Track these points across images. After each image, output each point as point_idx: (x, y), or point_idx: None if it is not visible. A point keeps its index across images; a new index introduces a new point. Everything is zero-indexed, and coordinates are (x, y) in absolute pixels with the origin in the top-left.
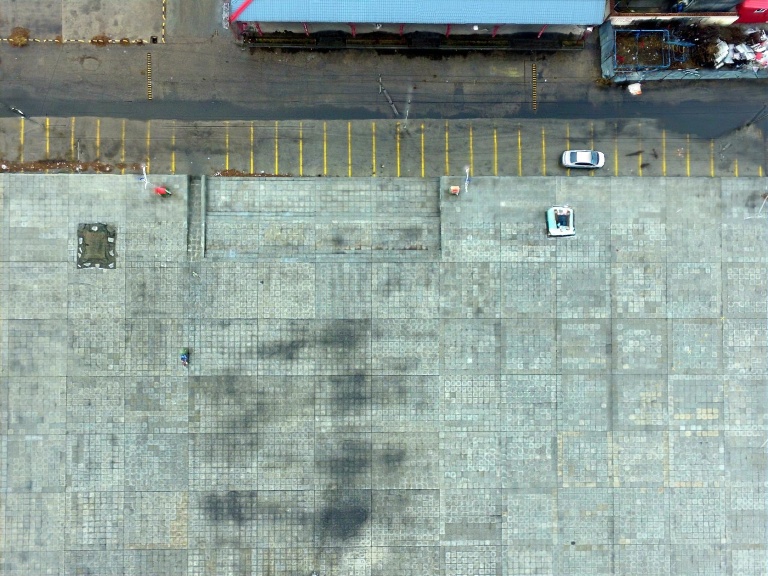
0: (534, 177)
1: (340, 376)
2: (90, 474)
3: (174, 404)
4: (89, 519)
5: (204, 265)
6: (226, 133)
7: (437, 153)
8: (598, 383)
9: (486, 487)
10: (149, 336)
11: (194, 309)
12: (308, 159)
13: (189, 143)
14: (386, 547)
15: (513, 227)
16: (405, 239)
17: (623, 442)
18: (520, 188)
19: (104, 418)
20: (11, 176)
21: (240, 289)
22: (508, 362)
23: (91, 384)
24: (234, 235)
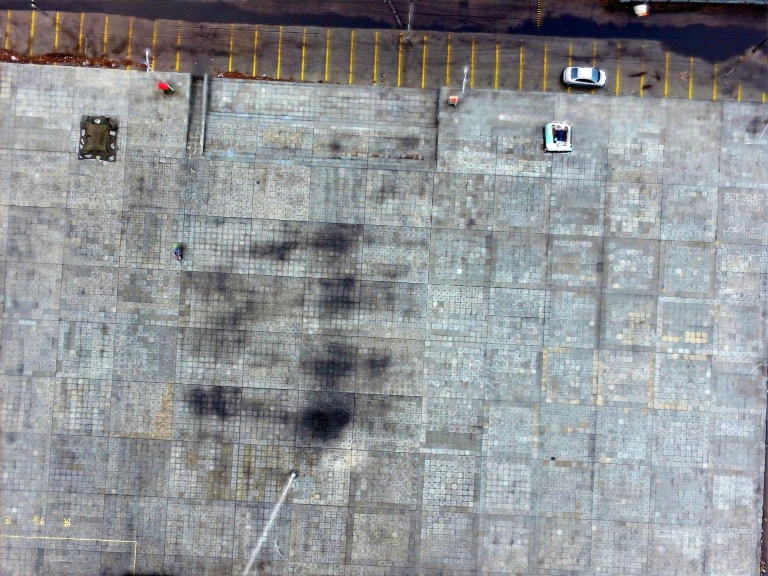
0: (534, 92)
1: (330, 279)
2: (80, 361)
3: (165, 297)
4: (77, 405)
5: (202, 163)
6: (231, 36)
7: (438, 65)
8: (587, 301)
9: (469, 397)
10: (145, 229)
11: (190, 205)
12: (310, 65)
13: (194, 44)
14: (366, 451)
15: (510, 141)
16: (401, 148)
17: (609, 361)
18: (519, 102)
19: (97, 307)
20: (19, 66)
21: (236, 188)
22: (498, 275)
23: (86, 273)
24: (233, 135)
